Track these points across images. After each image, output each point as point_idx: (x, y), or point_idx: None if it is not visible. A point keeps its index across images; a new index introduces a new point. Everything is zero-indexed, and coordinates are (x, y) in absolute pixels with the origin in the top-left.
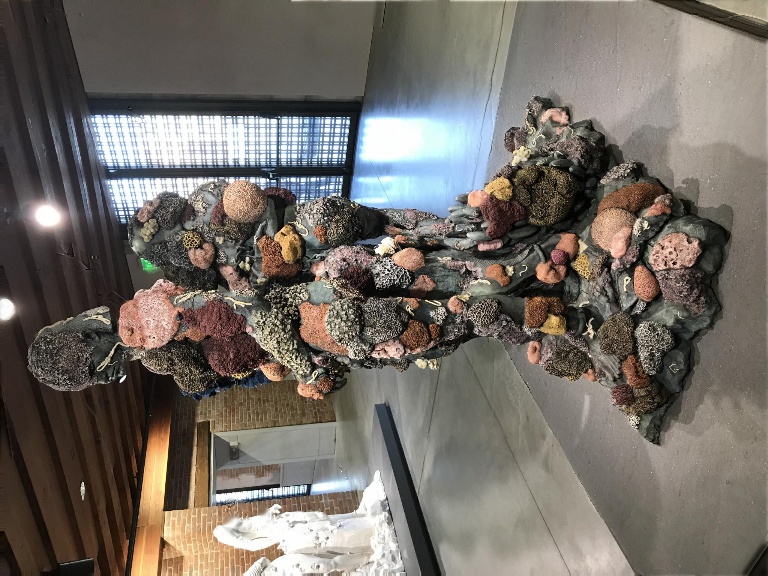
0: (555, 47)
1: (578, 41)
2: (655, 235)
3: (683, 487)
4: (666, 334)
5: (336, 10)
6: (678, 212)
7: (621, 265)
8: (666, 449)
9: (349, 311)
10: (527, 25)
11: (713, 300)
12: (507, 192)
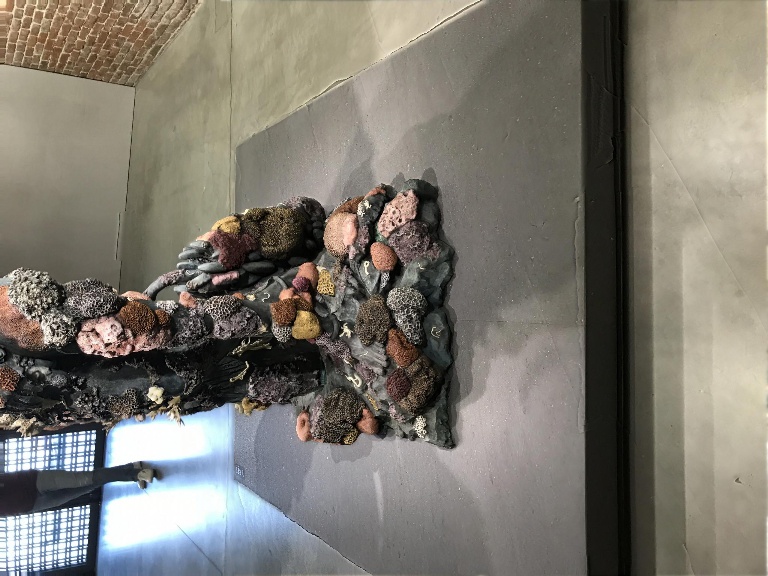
0: (271, 184)
1: (287, 163)
2: (379, 217)
3: (491, 468)
4: (415, 292)
5: (64, 242)
6: (392, 194)
7: (357, 250)
8: (462, 443)
9: (43, 277)
10: (246, 188)
11: (445, 245)
12: (234, 225)
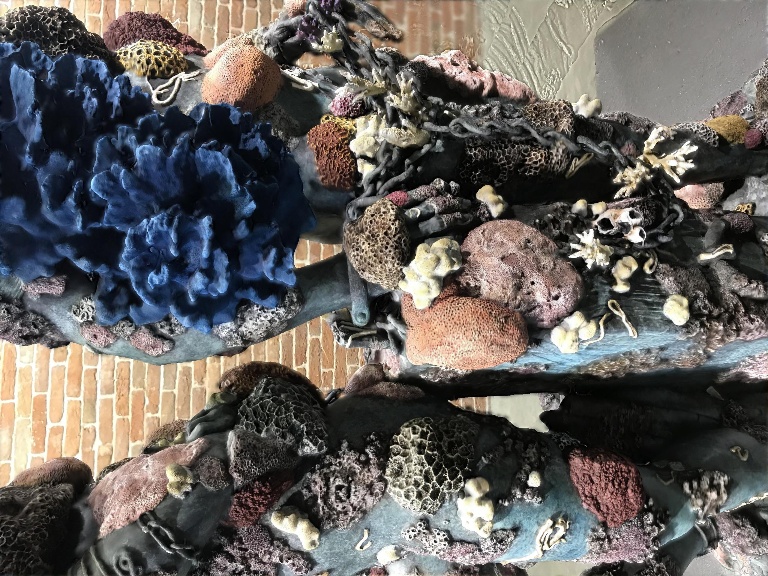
0: None
1: None
2: None
3: None
4: None
5: None
6: None
7: None
8: None
9: None
10: None
11: None
12: None
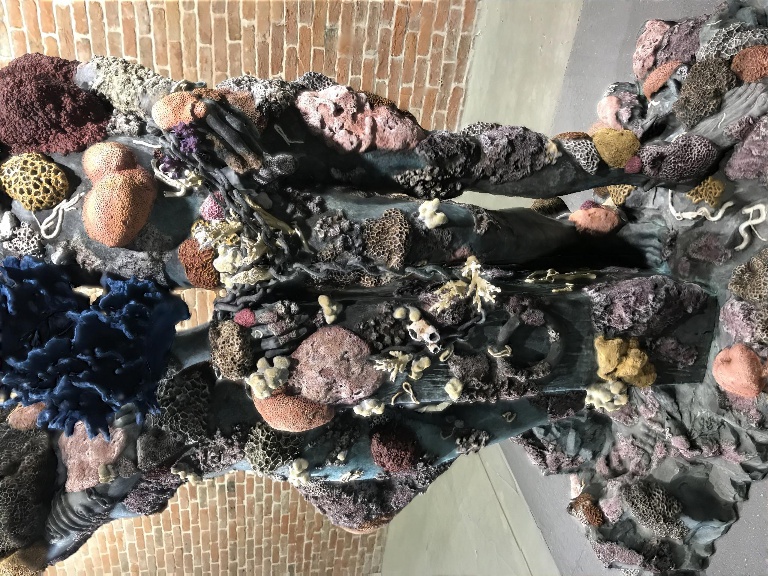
0: None
1: None
2: None
3: None
4: None
5: None
6: None
7: (629, 107)
8: None
9: None
10: None
11: None
12: None
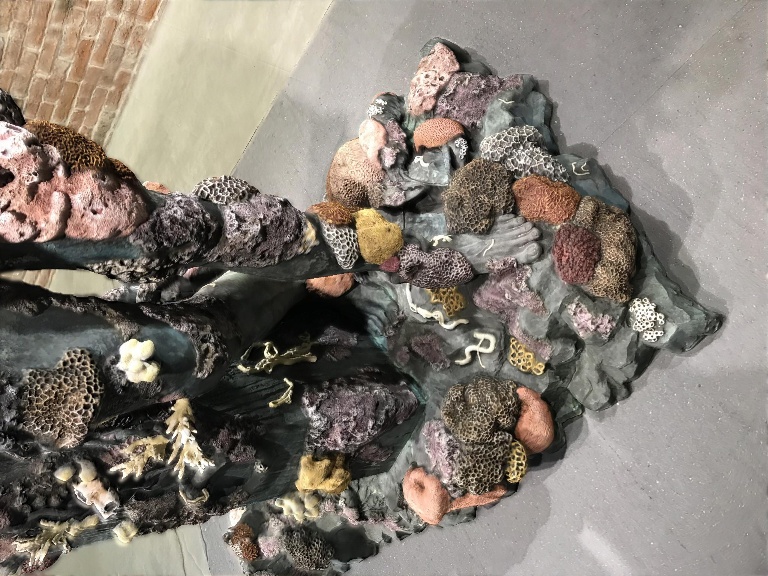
0: None
1: None
2: (402, 118)
3: None
4: None
5: None
6: None
7: (395, 150)
8: (736, 299)
9: None
10: None
11: None
12: None
